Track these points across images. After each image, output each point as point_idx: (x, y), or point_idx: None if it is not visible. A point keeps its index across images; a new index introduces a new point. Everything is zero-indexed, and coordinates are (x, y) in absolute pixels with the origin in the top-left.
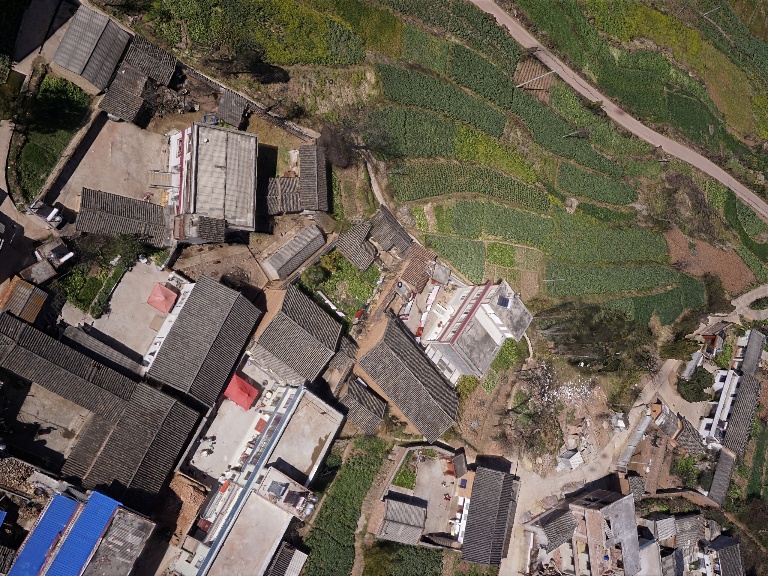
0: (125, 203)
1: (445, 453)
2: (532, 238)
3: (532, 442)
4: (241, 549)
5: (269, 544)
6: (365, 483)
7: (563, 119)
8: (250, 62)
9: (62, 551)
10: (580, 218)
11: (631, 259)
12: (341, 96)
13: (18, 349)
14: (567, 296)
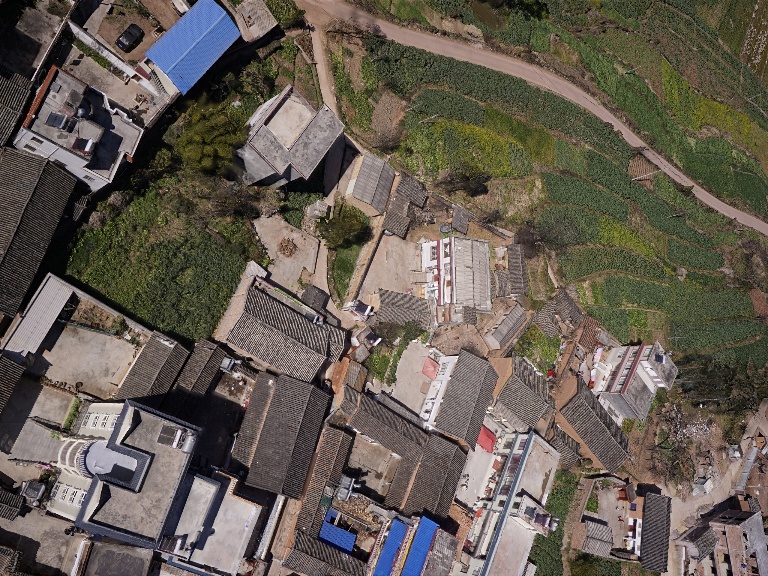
0: (404, 298)
1: (617, 483)
2: (658, 304)
3: (673, 472)
4: (504, 560)
5: (521, 556)
6: (565, 509)
7: (666, 203)
8: (462, 181)
9: (408, 561)
10: (689, 284)
11: (727, 316)
12: (521, 201)
13: (361, 412)
14: (686, 350)
